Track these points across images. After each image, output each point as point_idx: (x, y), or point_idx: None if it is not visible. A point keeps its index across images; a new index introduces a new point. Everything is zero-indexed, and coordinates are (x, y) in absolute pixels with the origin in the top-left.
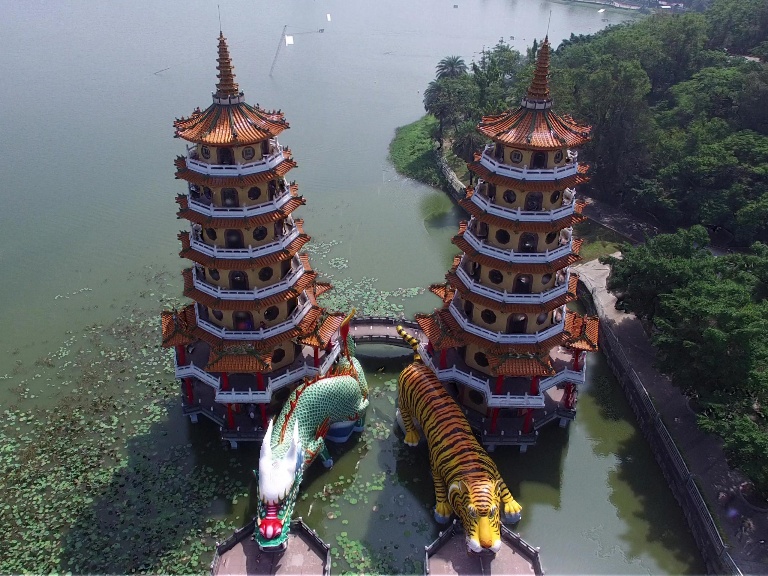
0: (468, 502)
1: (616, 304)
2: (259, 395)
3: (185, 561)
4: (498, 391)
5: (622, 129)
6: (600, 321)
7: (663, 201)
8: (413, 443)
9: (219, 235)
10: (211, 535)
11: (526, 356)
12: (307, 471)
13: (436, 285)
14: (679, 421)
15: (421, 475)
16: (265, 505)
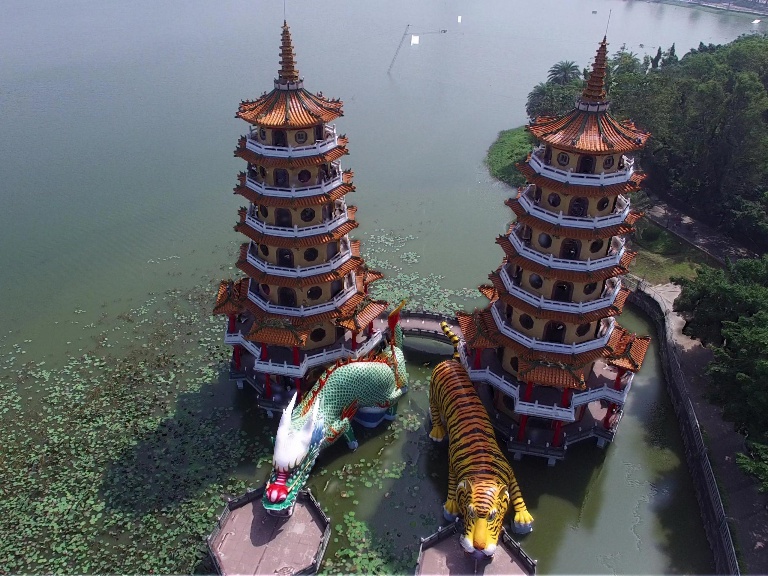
0: (469, 501)
1: (683, 328)
2: (293, 369)
3: (202, 511)
4: (527, 398)
5: (730, 145)
6: (667, 345)
7: (763, 226)
8: (437, 438)
9: (270, 213)
10: (231, 492)
11: (557, 366)
12: (331, 449)
13: (486, 286)
14: (730, 460)
15: (440, 471)
16: (276, 471)
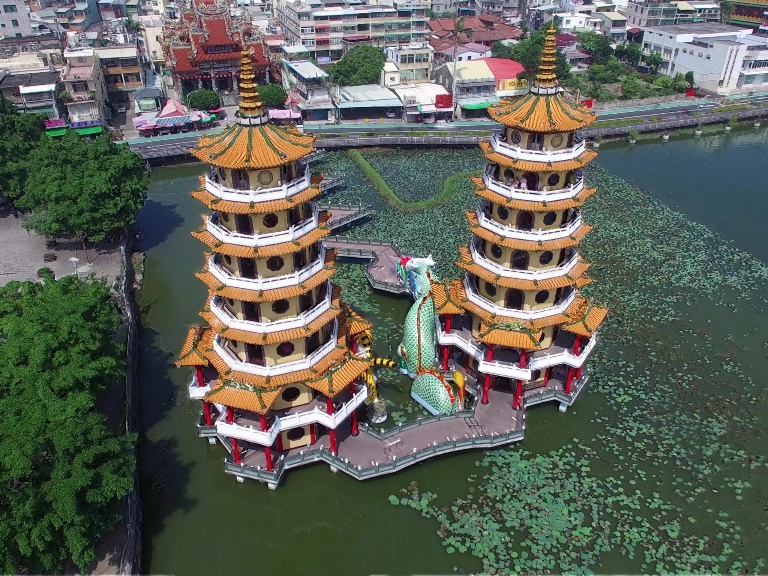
0: None
1: None
2: None
3: None
4: None
5: None
6: None
7: None
8: None
9: None
10: None
11: None
12: None
13: (364, 358)
14: (104, 417)
15: None
16: None
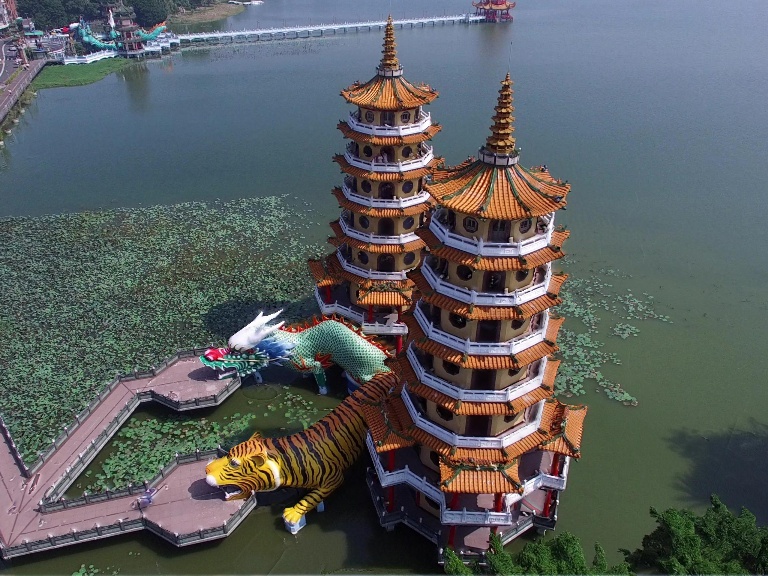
0: None
1: None
2: None
3: None
4: None
5: None
6: None
7: None
8: None
9: None
10: None
11: None
12: None
13: None
14: None
15: None
16: None
